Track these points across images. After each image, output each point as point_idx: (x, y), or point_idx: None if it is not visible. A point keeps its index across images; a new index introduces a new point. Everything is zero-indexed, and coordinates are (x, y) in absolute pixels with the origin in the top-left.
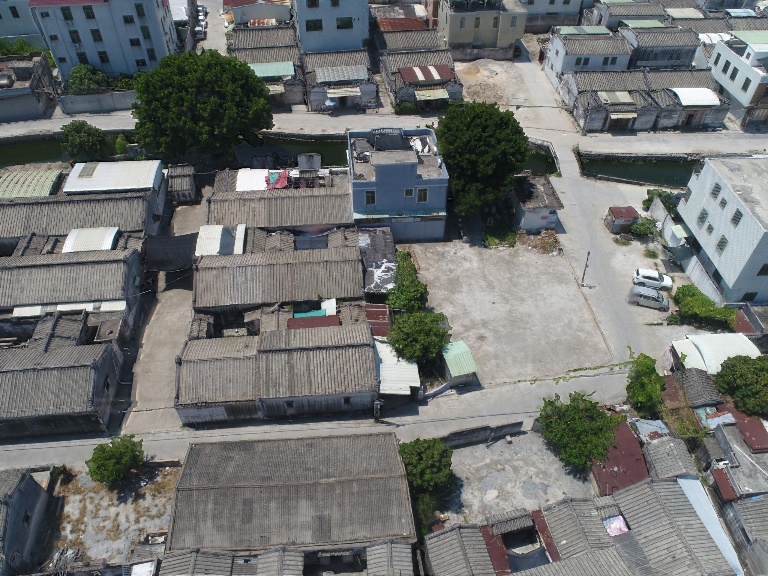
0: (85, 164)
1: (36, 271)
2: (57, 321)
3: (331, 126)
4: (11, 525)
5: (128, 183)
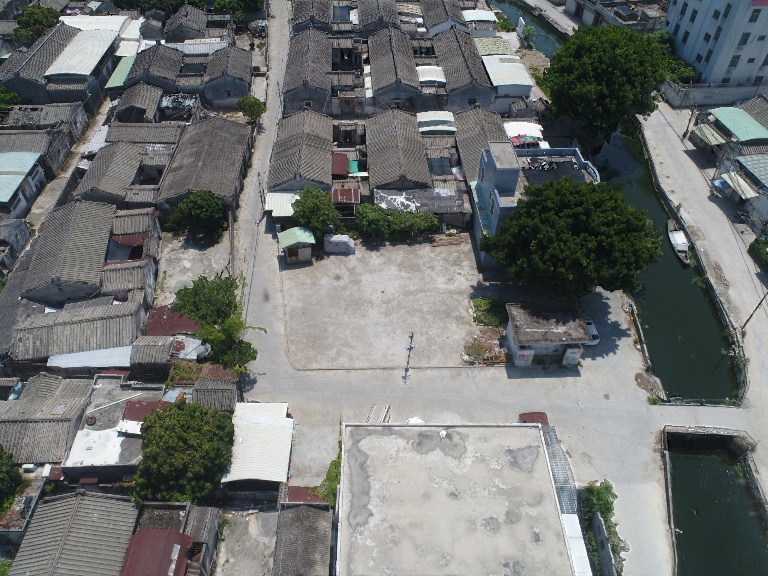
0: (518, 59)
1: (391, 58)
2: (350, 73)
3: (686, 196)
4: (218, 83)
5: (496, 76)
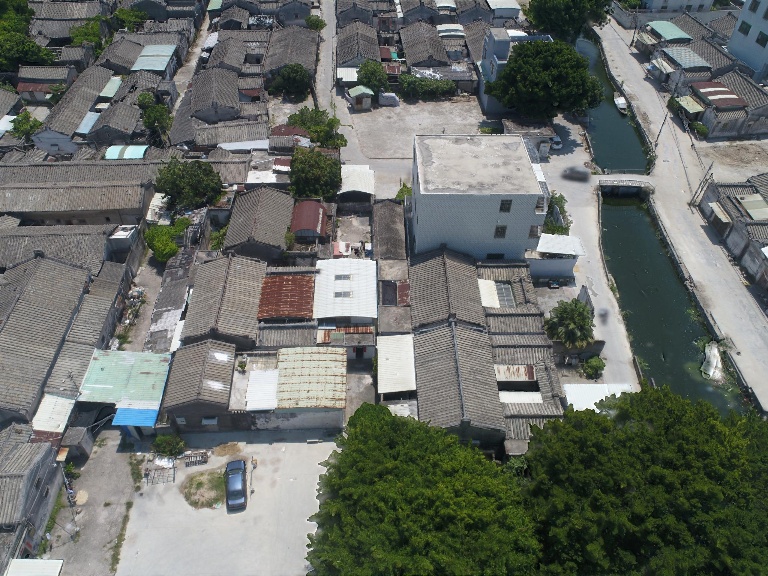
0: None
1: None
2: (385, 2)
3: (628, 78)
4: (289, 7)
5: (494, 3)
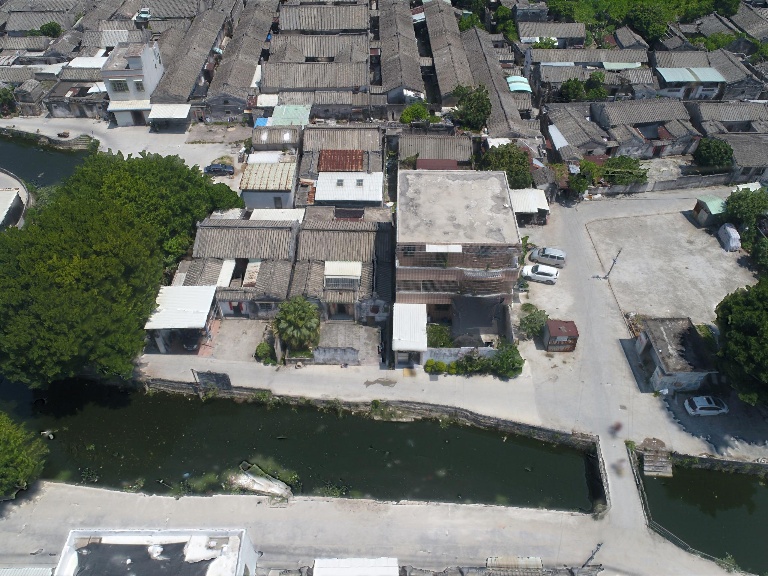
0: None
1: None
2: None
3: None
4: None
5: None
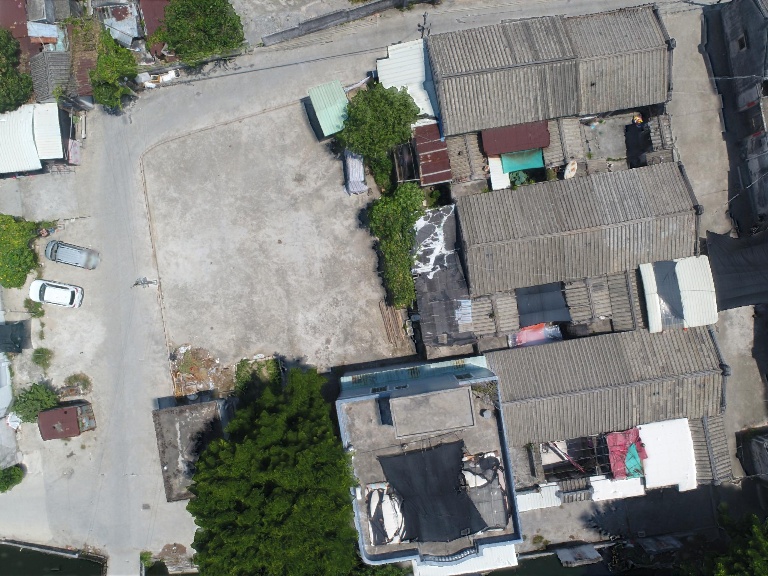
0: None
1: None
2: None
3: None
4: None
5: None
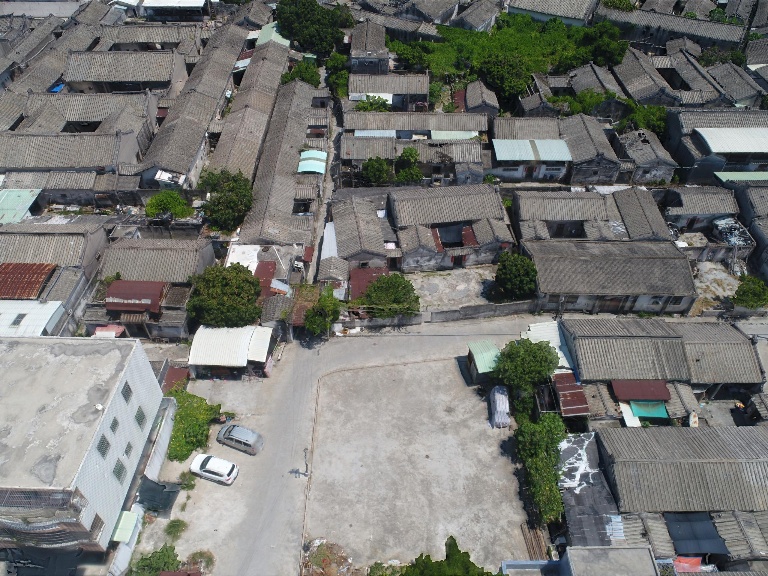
0: None
1: None
2: None
3: None
4: None
5: None
